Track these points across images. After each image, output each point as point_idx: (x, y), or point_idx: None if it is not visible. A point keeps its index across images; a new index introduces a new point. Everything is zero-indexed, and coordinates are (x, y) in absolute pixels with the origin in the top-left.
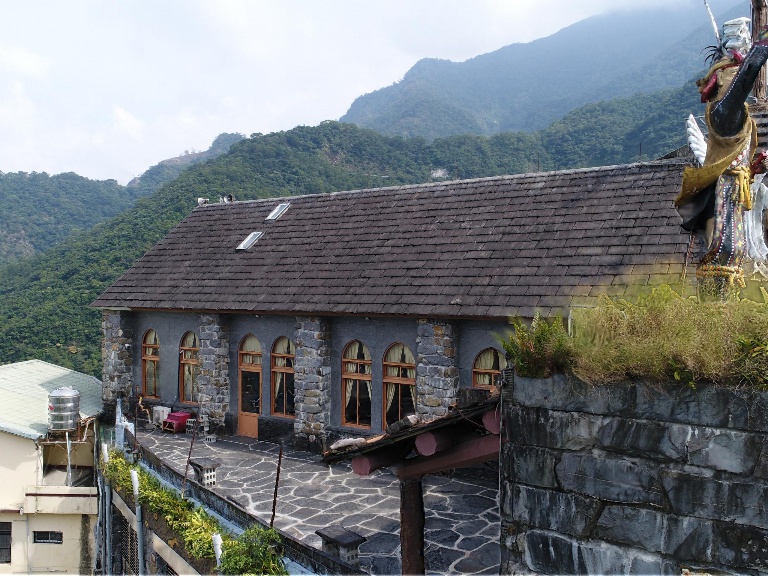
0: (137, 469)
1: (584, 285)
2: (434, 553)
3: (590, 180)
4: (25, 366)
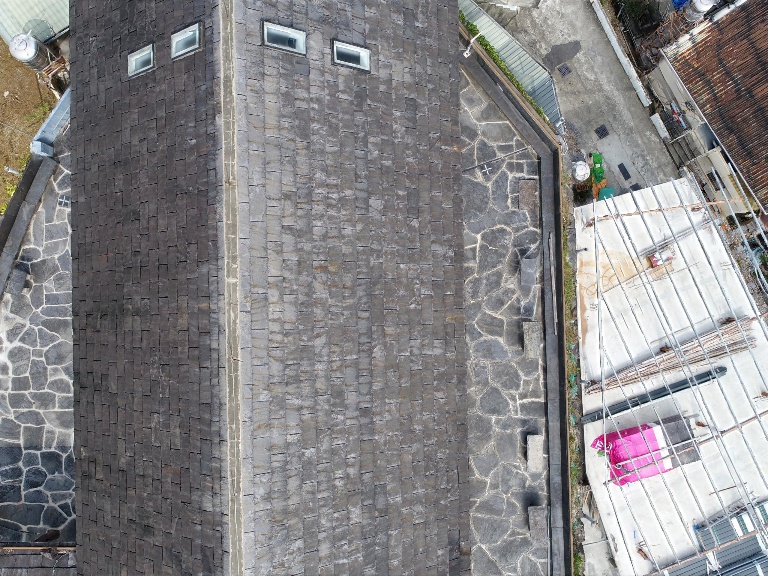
0: None
1: (98, 574)
2: (9, 488)
3: (209, 575)
4: None
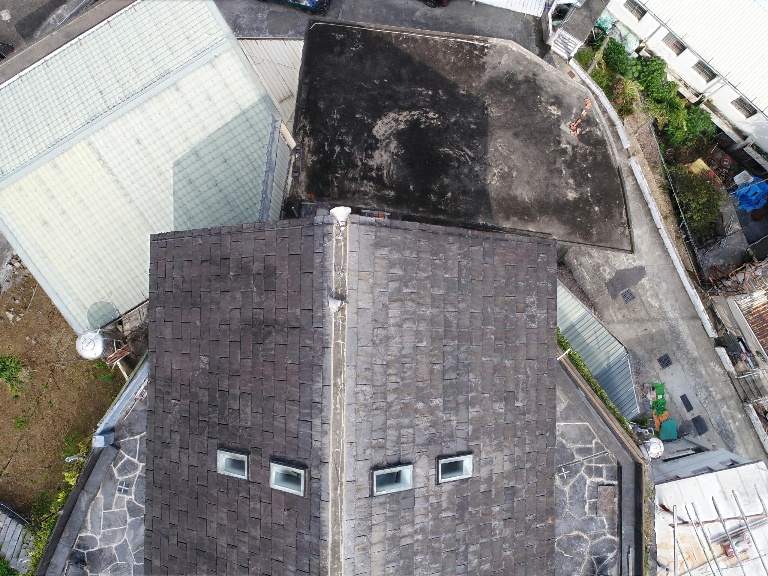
0: (47, 533)
1: None
2: None
3: None
4: (198, 77)
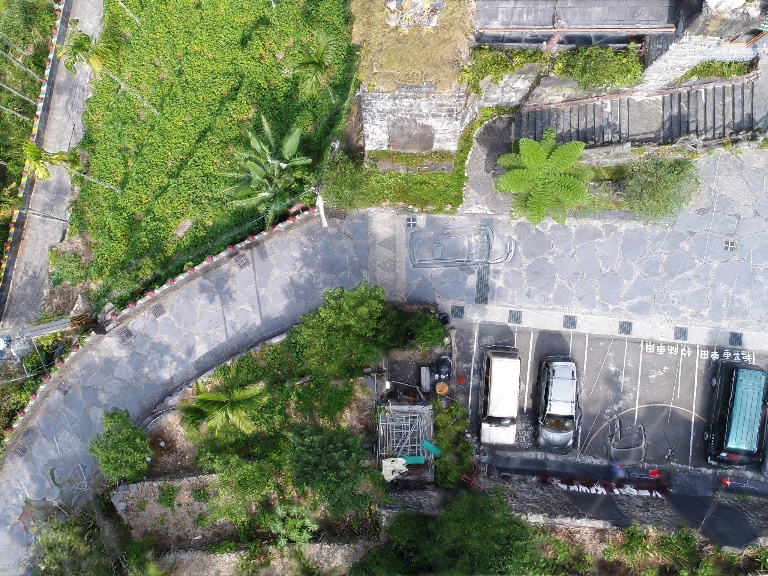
0: None
1: None
2: None
3: None
4: None
